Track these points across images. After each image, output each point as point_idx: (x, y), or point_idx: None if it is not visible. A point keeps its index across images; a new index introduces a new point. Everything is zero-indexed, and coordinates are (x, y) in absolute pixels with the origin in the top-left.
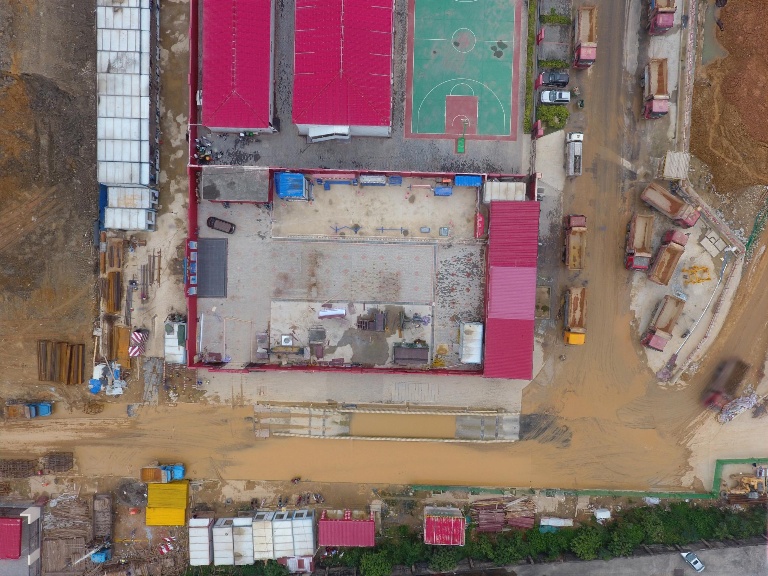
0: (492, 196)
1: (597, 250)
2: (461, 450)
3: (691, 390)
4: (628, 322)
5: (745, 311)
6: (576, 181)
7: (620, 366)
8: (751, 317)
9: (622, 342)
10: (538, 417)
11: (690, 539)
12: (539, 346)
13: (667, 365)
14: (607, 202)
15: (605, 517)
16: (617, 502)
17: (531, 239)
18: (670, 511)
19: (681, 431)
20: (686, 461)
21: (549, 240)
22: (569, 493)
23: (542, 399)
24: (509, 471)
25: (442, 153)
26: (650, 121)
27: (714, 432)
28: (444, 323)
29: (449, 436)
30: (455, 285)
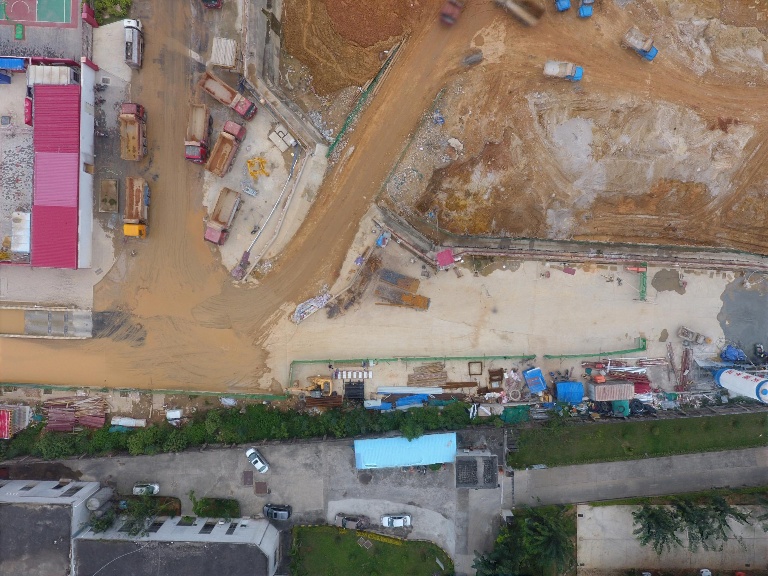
0: (36, 80)
1: (167, 143)
2: (33, 347)
3: (264, 289)
4: (201, 218)
5: (328, 211)
6: (144, 72)
7: (194, 263)
8: (334, 217)
9: (196, 239)
10: (111, 314)
11: (245, 437)
12: (109, 241)
13: (240, 263)
14: (176, 94)
15: (175, 417)
16: (193, 403)
17: (72, 124)
18: (244, 413)
19: (256, 331)
20: (263, 362)
21: (117, 132)
22: (144, 393)
23: (115, 296)
24: (82, 370)
25: (1, 39)
26: (217, 12)
27: (290, 333)
28: (9, 215)
29: (19, 332)
30: (20, 176)
